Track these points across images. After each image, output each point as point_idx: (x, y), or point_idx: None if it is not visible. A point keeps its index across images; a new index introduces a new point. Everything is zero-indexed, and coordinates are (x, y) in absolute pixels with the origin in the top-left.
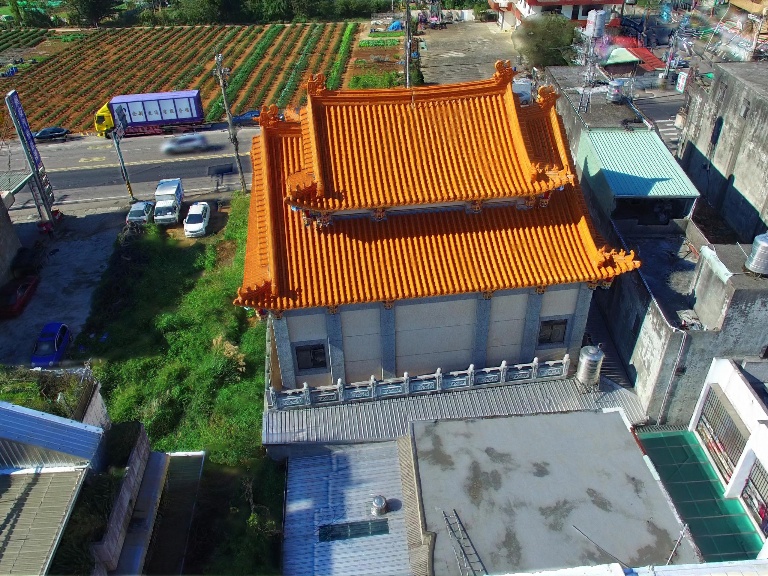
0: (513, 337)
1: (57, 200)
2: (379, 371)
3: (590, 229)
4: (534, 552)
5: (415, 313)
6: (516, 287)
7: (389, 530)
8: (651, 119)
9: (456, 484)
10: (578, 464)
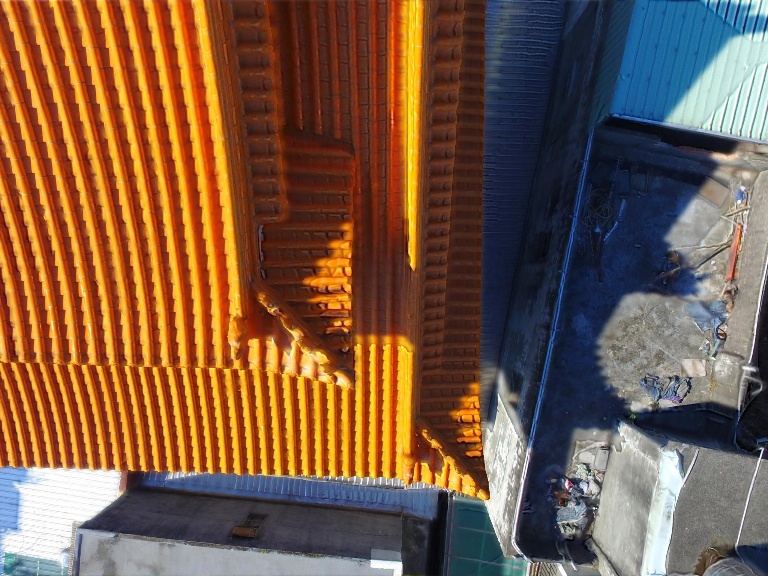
0: None
1: None
2: None
3: (427, 360)
4: None
5: None
6: None
7: None
8: None
9: None
10: None
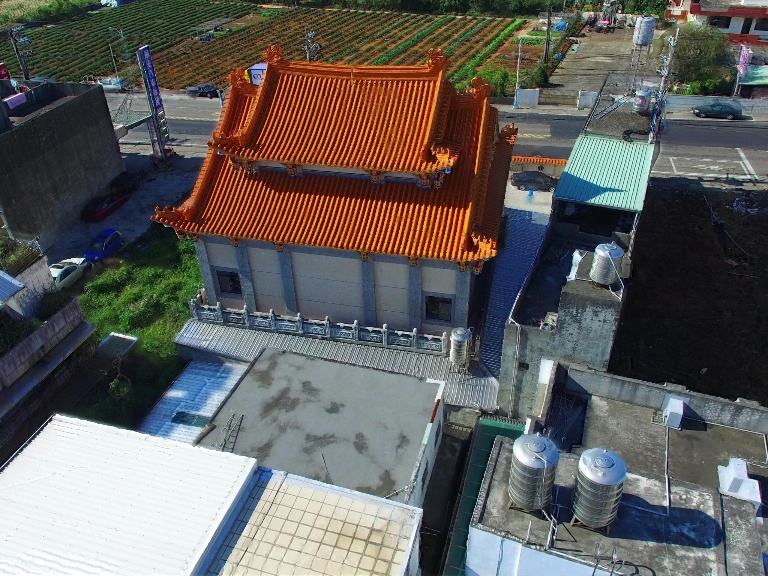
0: (401, 305)
1: (179, 142)
2: (285, 309)
3: (477, 216)
4: (275, 461)
5: (310, 262)
6: (380, 252)
7: None
8: (656, 132)
9: (260, 399)
10: (368, 413)
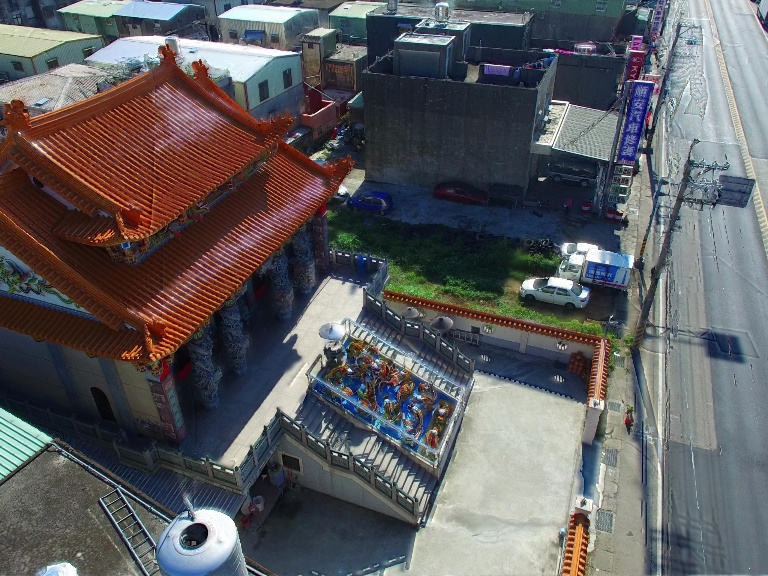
0: None
1: None
2: None
3: None
4: None
5: None
6: None
7: None
8: None
9: None
10: None
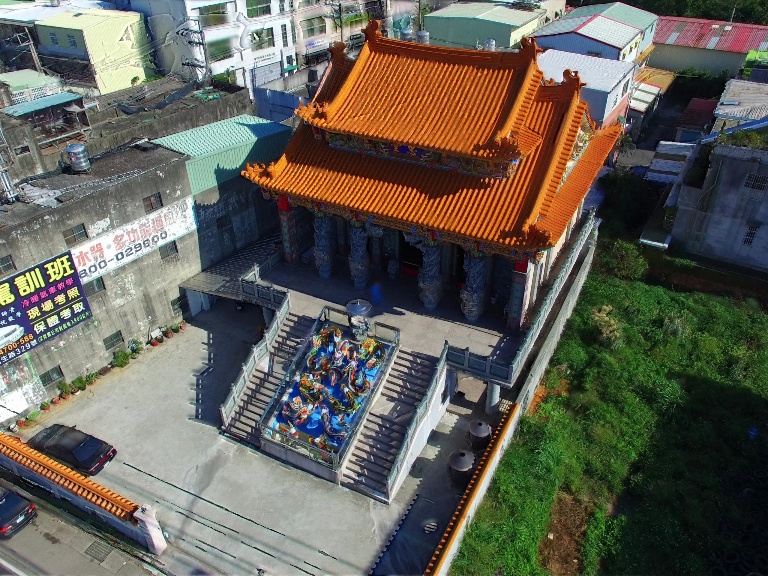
0: None
1: None
2: None
3: None
4: None
5: None
6: None
7: None
8: None
9: None
10: None
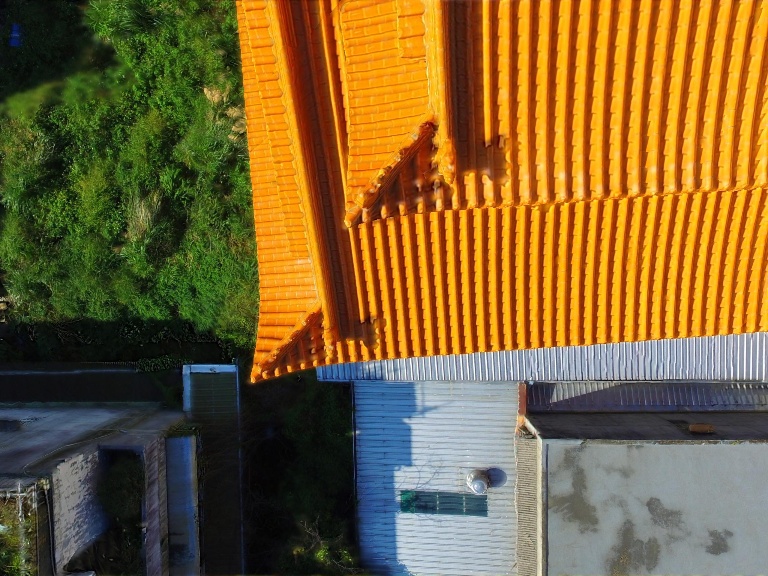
0: None
1: None
2: None
3: None
4: None
5: None
6: None
7: (488, 512)
8: None
9: (596, 557)
10: None
